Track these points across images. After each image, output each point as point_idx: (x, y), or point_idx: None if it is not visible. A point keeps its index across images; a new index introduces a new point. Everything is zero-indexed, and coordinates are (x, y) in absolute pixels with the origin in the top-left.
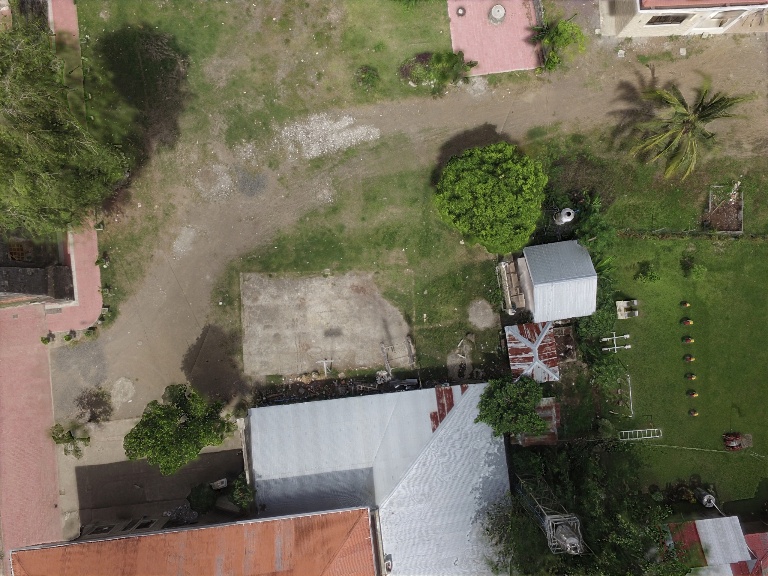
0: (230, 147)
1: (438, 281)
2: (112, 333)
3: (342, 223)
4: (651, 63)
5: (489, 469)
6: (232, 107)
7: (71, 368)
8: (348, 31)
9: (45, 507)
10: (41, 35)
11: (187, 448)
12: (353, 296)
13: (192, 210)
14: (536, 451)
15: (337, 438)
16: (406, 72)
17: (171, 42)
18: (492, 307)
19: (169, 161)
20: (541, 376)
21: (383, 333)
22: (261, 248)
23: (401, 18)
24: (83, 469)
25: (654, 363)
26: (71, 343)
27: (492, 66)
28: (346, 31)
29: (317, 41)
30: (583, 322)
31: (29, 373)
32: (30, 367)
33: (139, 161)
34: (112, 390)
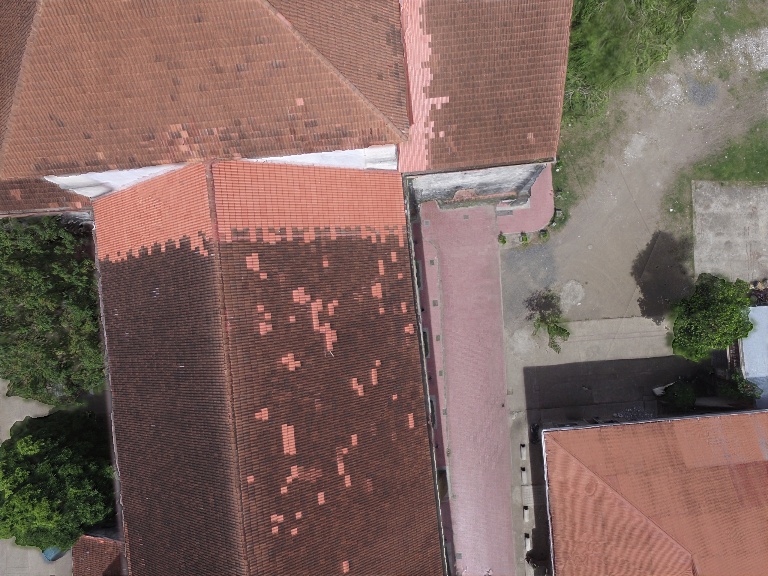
0: (681, 57)
1: None
2: (562, 236)
3: None
4: None
5: None
6: None
7: (521, 270)
8: None
9: (493, 406)
10: None
11: (749, 329)
12: None
13: (643, 118)
14: None
15: None
16: None
17: None
18: None
19: None
20: None
21: None
22: (711, 157)
23: None
24: (531, 369)
25: None
26: (522, 245)
27: None
28: None
29: None
30: None
31: (479, 273)
32: (480, 267)
33: None
34: (562, 292)
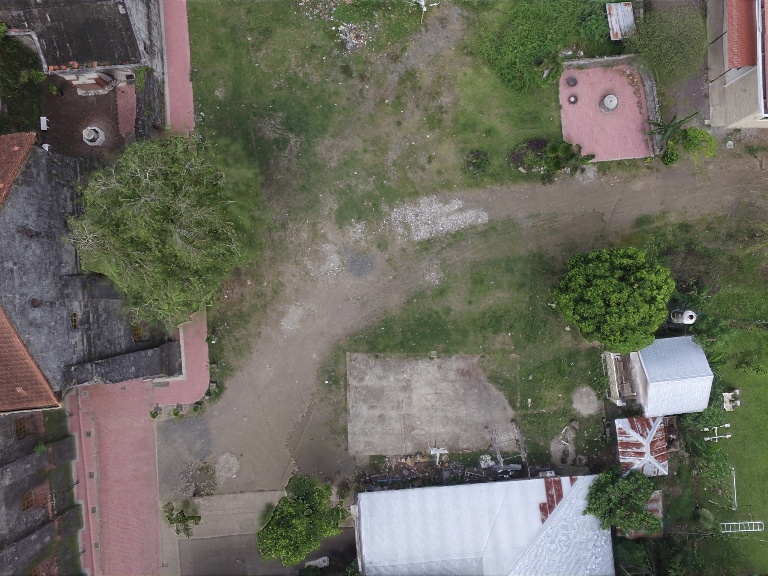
0: (340, 227)
1: (543, 367)
2: (218, 408)
3: (449, 306)
4: (759, 155)
5: (596, 561)
6: (342, 187)
7: (177, 441)
8: (459, 115)
9: None
10: (159, 113)
11: (316, 545)
12: (459, 379)
13: (300, 288)
14: (639, 541)
15: (447, 526)
16: (517, 159)
17: (284, 121)
18: (596, 394)
19: (279, 239)
20: (651, 470)
21: (487, 417)
22: (368, 328)
23: (512, 103)
24: (186, 542)
25: (754, 453)
26: (177, 417)
27: (601, 154)
28: (457, 115)
29: (428, 124)
30: (692, 416)
31: (135, 445)
32: (136, 439)
33: (250, 238)
34: (217, 465)
